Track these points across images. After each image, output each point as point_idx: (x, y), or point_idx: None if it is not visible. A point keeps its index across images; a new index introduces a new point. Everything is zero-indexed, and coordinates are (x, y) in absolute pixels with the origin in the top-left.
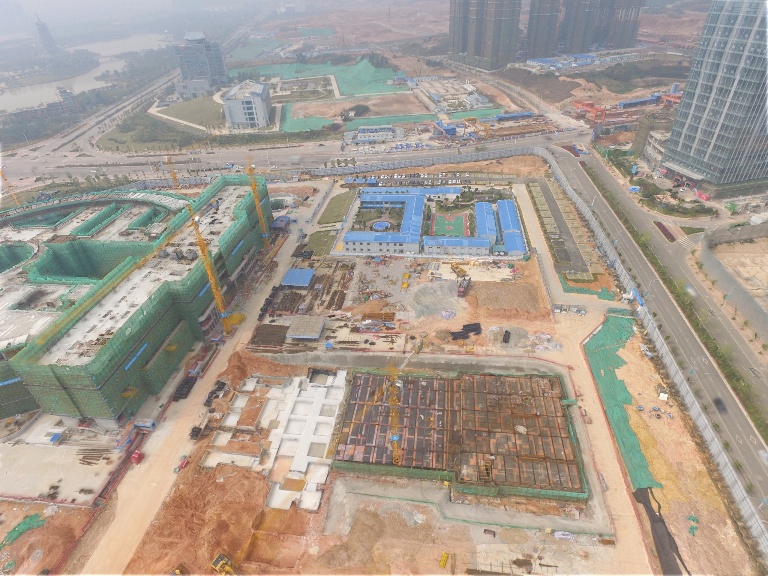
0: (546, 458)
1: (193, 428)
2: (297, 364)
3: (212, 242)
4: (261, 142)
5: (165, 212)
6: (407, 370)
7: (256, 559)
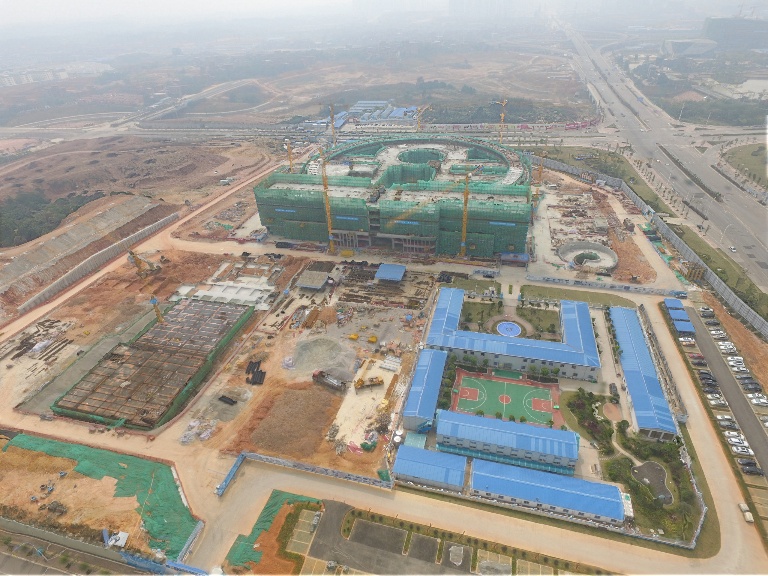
0: (93, 392)
1: (250, 253)
2: None
3: None
4: None
5: None
6: None
7: (156, 282)
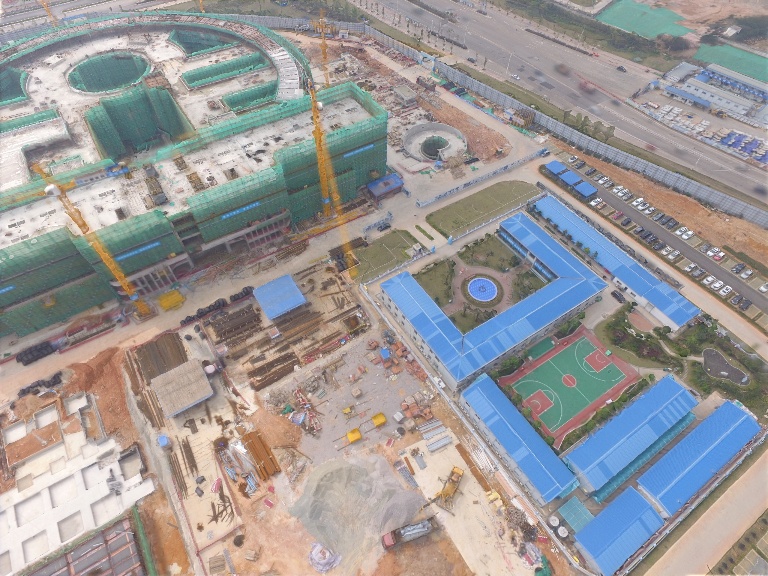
0: None
1: None
2: (134, 424)
3: (209, 188)
4: (555, 23)
5: (274, 96)
6: (189, 574)
7: None
